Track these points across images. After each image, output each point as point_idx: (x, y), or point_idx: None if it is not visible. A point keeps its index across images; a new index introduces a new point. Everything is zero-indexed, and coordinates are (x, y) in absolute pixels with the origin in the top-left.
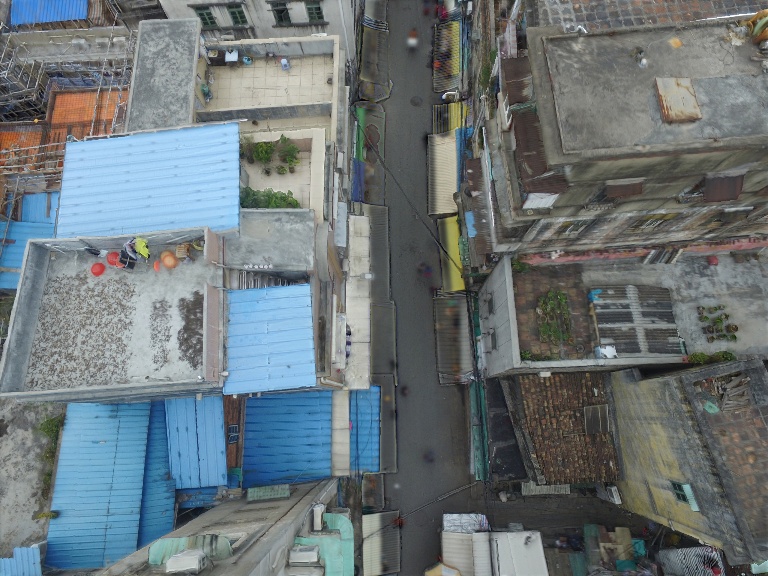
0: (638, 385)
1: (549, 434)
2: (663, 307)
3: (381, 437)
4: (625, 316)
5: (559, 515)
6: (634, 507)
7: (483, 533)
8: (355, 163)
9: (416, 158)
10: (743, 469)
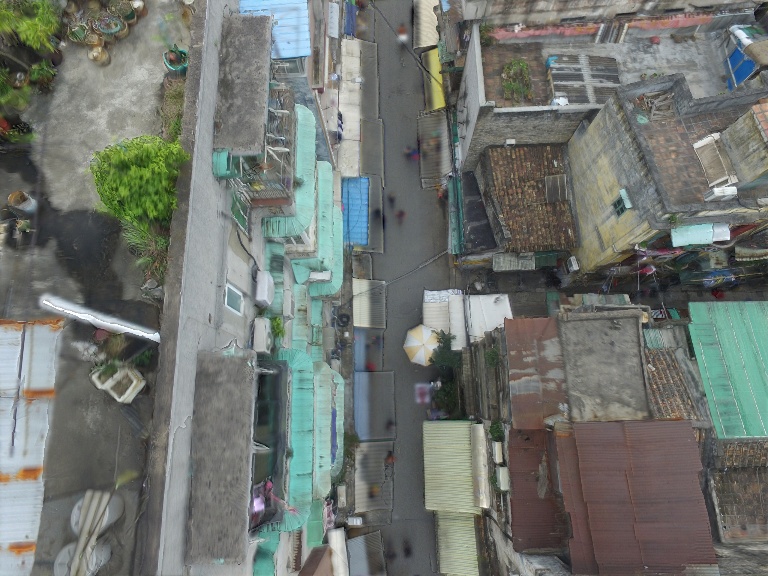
0: (587, 132)
1: (515, 203)
2: (610, 71)
3: (369, 223)
4: (577, 76)
5: (528, 306)
6: (588, 264)
7: (458, 295)
8: (348, 4)
9: (404, 16)
10: (666, 162)
